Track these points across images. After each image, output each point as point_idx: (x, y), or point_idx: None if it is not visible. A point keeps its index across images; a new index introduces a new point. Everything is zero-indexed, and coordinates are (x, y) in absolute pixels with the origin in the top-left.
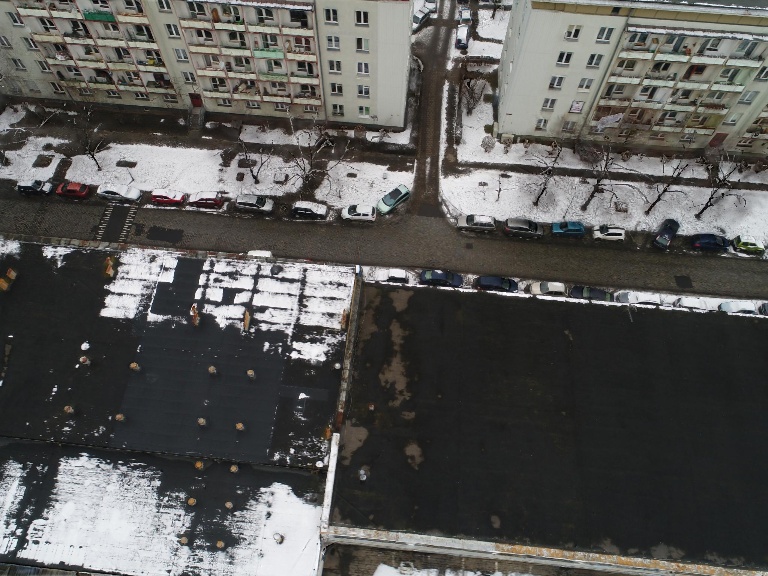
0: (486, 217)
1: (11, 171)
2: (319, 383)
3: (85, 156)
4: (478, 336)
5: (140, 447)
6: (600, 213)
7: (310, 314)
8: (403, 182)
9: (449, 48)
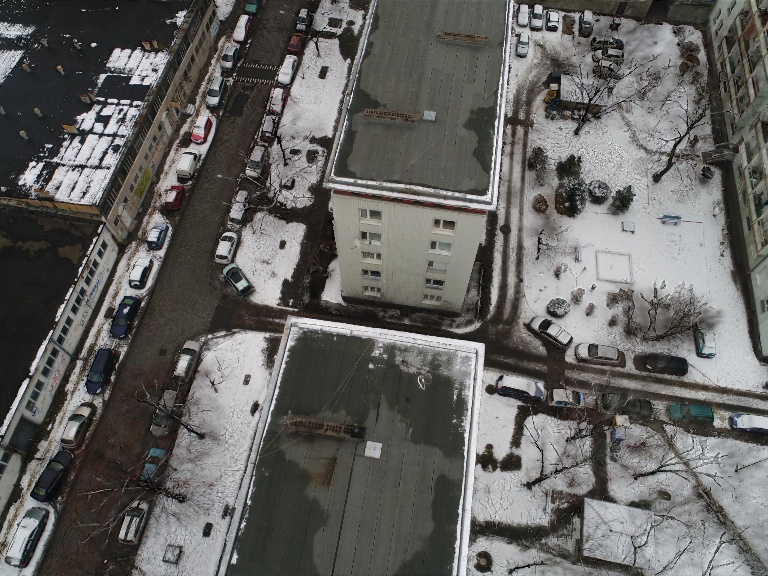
0: (184, 367)
1: (326, 7)
2: (1, 181)
3: (337, 46)
4: (4, 313)
5: (5, 83)
6: (171, 521)
7: (65, 173)
8: (265, 293)
9: (501, 371)
